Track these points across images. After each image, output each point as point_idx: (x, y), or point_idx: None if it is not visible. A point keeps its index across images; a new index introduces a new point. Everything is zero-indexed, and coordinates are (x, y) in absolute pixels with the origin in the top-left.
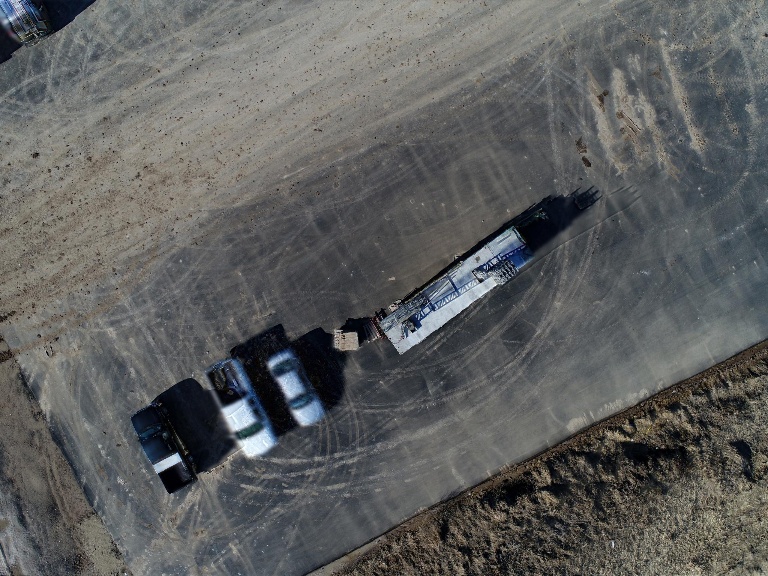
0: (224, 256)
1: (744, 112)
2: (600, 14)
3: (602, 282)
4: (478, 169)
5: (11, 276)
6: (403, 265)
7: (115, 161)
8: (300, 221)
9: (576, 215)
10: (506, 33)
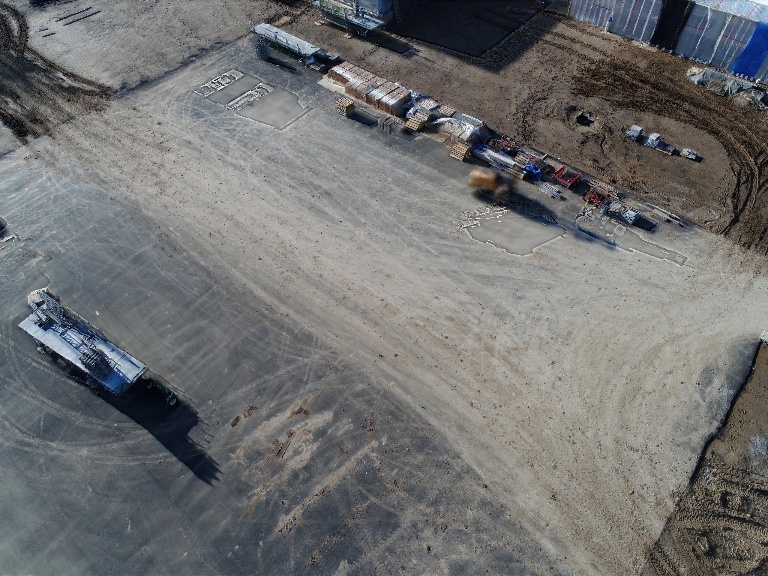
0: (104, 215)
1: (337, 561)
2: (375, 380)
3: (114, 485)
4: (206, 339)
5: (79, 132)
6: (111, 316)
7: (163, 152)
8: (138, 245)
9: (181, 433)
10: (328, 319)
